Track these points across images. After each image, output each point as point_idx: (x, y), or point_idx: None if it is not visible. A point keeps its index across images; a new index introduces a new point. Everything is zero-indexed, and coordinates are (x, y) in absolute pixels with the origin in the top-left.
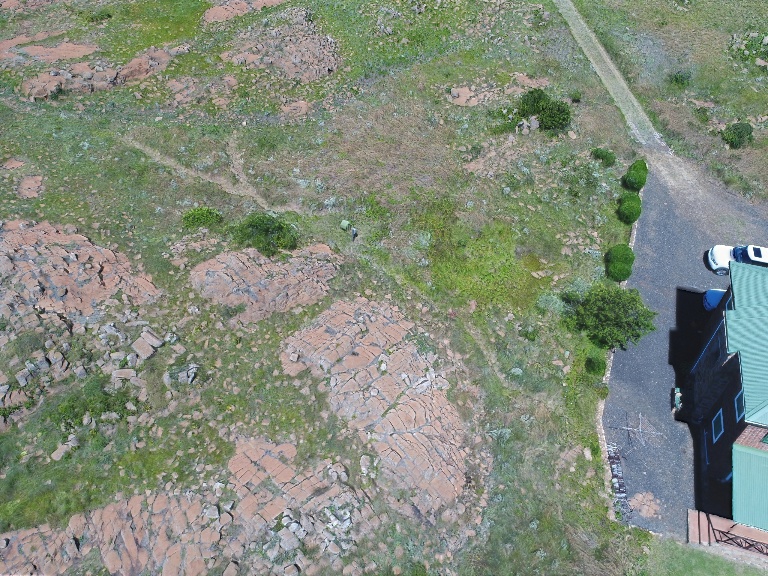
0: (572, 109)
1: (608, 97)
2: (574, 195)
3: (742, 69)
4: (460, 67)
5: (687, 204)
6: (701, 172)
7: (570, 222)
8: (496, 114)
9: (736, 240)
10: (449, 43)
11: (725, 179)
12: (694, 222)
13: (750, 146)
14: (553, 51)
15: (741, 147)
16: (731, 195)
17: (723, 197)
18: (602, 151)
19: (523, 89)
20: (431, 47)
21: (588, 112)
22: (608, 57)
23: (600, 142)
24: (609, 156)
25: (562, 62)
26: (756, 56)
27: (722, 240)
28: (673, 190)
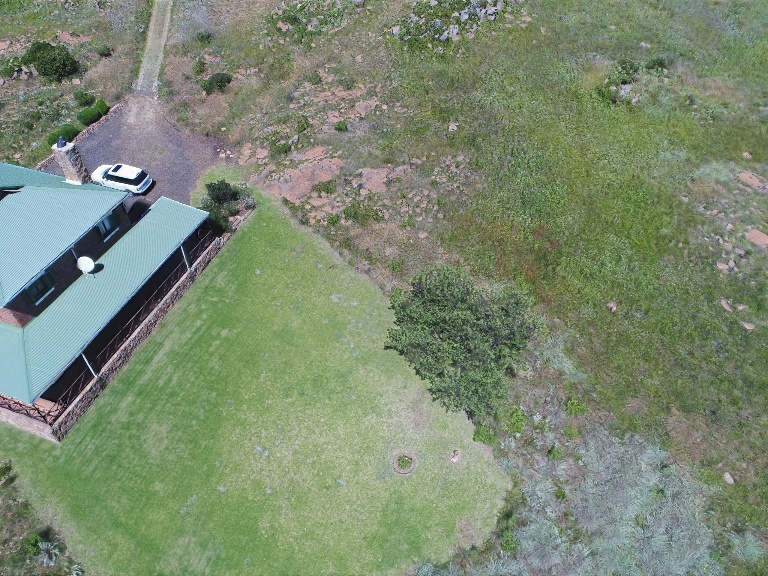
0: (97, 62)
1: (136, 52)
2: (25, 126)
3: (263, 30)
4: (16, 26)
5: (128, 136)
6: (166, 112)
7: (2, 146)
8: (5, 62)
9: (143, 164)
10: (27, 7)
11: (177, 118)
12: (121, 150)
13: (220, 92)
14: (111, 14)
15: (212, 93)
16: (174, 130)
17: (165, 132)
18: (81, 93)
19: (55, 44)
20: (7, 10)
21: (103, 64)
22: (169, 21)
23: (94, 87)
24: (82, 97)
25: (113, 23)
26: (278, 19)
27: (130, 164)
28: (127, 126)
